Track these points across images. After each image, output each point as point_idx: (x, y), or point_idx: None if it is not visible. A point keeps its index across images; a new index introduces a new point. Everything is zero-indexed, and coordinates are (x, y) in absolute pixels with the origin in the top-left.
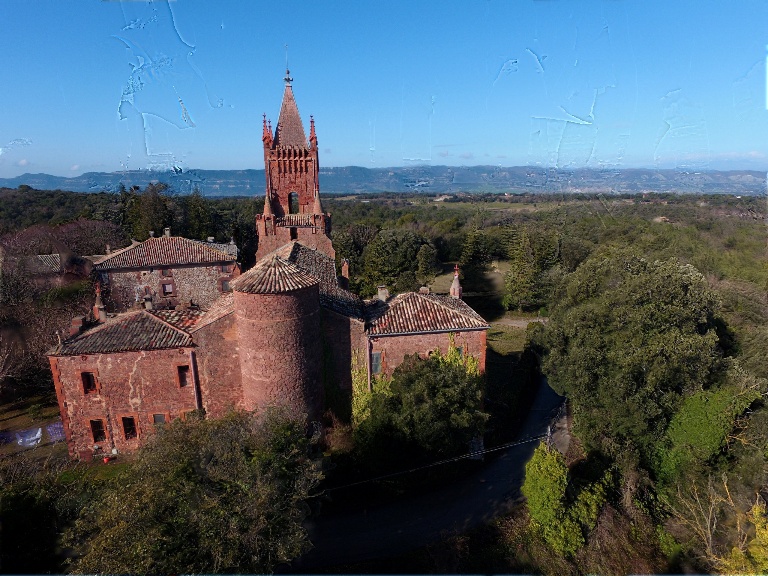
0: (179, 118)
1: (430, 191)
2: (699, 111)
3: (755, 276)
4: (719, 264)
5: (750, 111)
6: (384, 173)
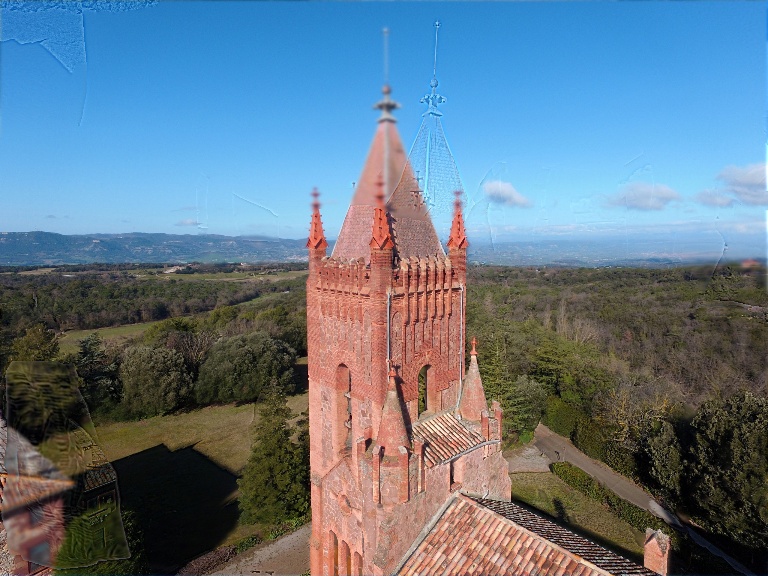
0: (339, 175)
1: (277, 280)
2: (620, 209)
3: (754, 375)
4: (723, 366)
5: (638, 211)
6: (220, 259)
